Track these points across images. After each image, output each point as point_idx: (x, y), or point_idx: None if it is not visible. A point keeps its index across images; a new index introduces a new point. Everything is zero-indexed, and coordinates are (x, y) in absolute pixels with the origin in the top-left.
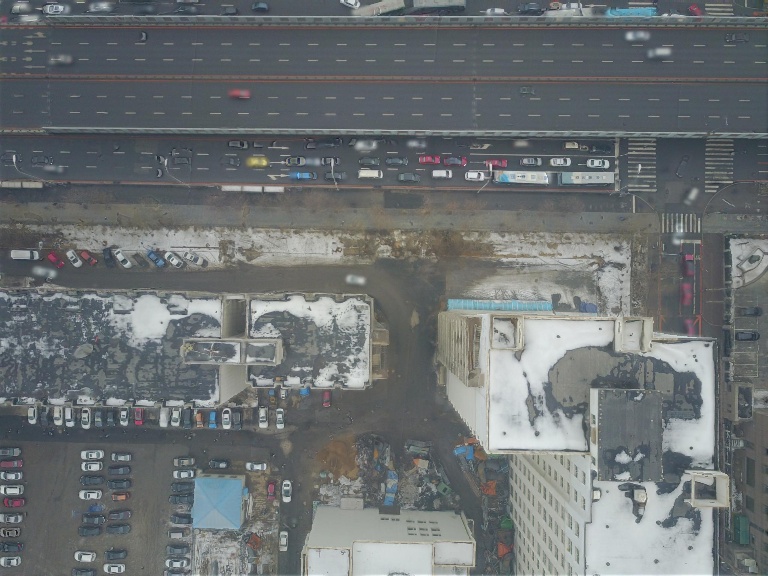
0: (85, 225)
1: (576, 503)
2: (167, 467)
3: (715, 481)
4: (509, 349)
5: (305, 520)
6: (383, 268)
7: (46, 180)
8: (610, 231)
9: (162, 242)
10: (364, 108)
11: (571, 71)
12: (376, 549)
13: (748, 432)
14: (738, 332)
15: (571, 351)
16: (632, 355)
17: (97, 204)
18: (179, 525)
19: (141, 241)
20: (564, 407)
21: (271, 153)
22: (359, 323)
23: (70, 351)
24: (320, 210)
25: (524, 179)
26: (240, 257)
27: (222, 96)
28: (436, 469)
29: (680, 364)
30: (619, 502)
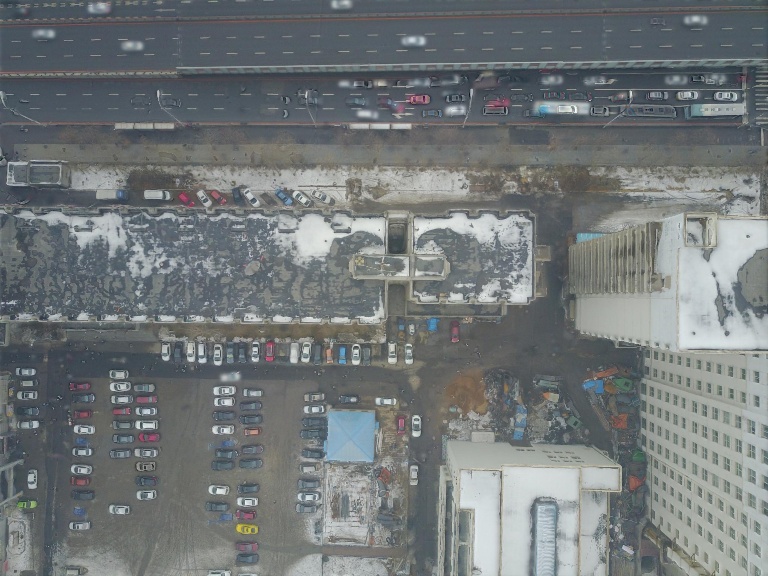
0: (214, 165)
1: (758, 408)
2: (297, 403)
3: None
4: (703, 247)
5: (435, 454)
6: (509, 204)
7: (179, 120)
8: (739, 164)
9: (289, 181)
10: (493, 43)
11: (703, 1)
12: (523, 473)
13: None
14: None
15: (760, 251)
16: None
17: (225, 145)
18: (310, 460)
19: (269, 181)
20: (754, 307)
21: (395, 92)
22: (521, 239)
23: (236, 270)
24: (445, 147)
25: (652, 112)
26: (367, 195)
27: (350, 34)
28: (565, 403)
29: None
30: None
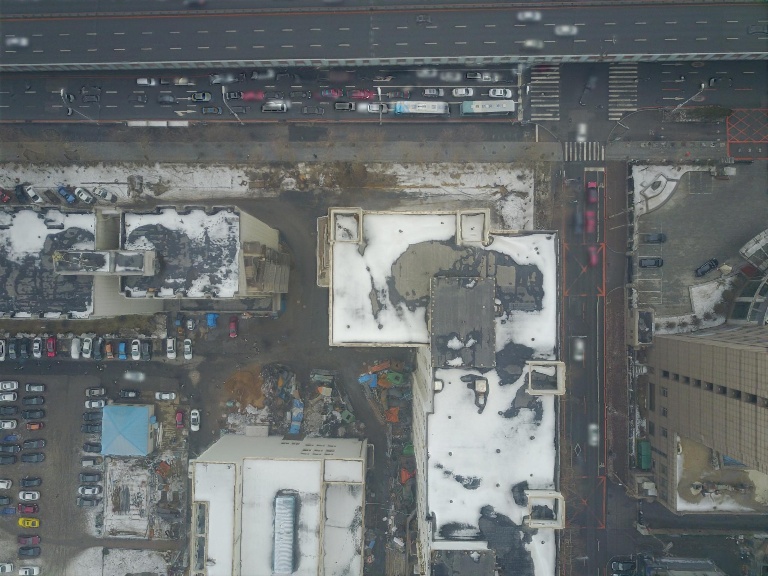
0: None
1: None
2: (80, 398)
3: (556, 371)
4: (347, 241)
5: None
6: (288, 200)
7: None
8: (512, 160)
9: (72, 178)
10: (263, 40)
11: None
12: (266, 466)
13: (650, 357)
14: (642, 259)
15: (413, 245)
16: (474, 249)
17: (10, 142)
18: (92, 454)
19: (52, 178)
20: (407, 300)
21: (178, 90)
22: (230, 235)
23: None
24: (225, 144)
25: (424, 109)
26: (148, 192)
27: (125, 32)
28: (341, 398)
29: (522, 257)
30: (461, 393)
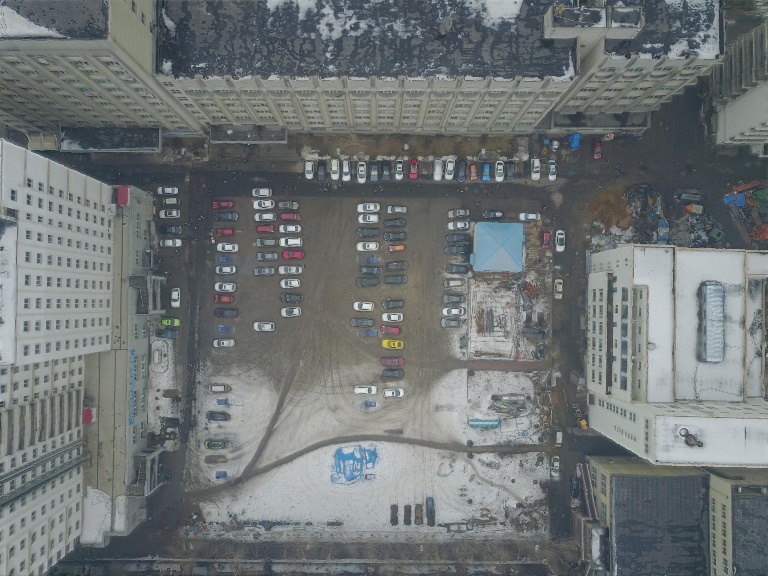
0: None
1: None
2: (441, 220)
3: None
4: None
5: (578, 269)
6: None
7: None
8: None
9: None
10: None
11: None
12: (689, 258)
13: None
14: None
15: None
16: None
17: None
18: (454, 276)
19: None
20: None
21: None
22: None
23: (426, 32)
24: None
25: None
26: None
27: None
28: (706, 217)
29: None
30: None
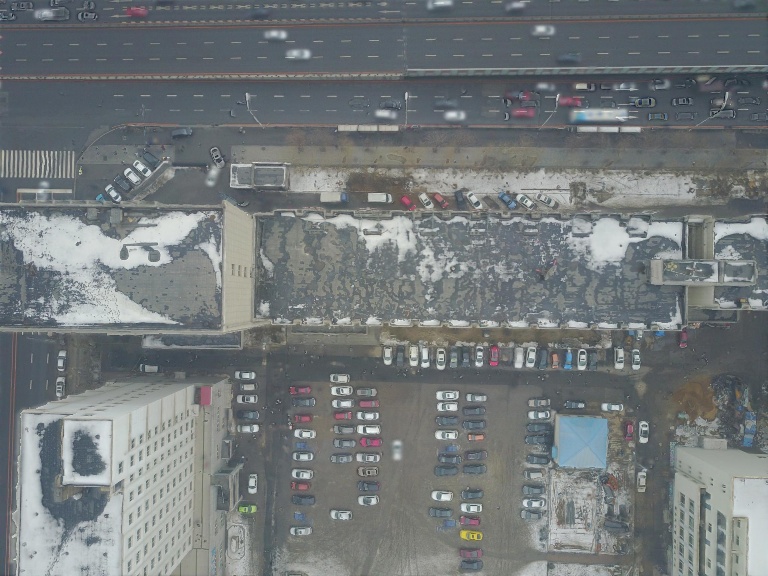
0: (436, 168)
1: None
2: (521, 408)
3: None
4: None
5: (662, 461)
6: (737, 208)
7: (406, 122)
8: None
9: (512, 184)
10: (728, 46)
11: None
12: None
13: None
14: None
15: None
16: None
17: (446, 148)
18: (534, 465)
19: (491, 184)
20: None
21: (618, 95)
22: None
23: (529, 274)
24: (671, 151)
25: None
26: (591, 199)
27: (581, 36)
28: None
29: None
30: None
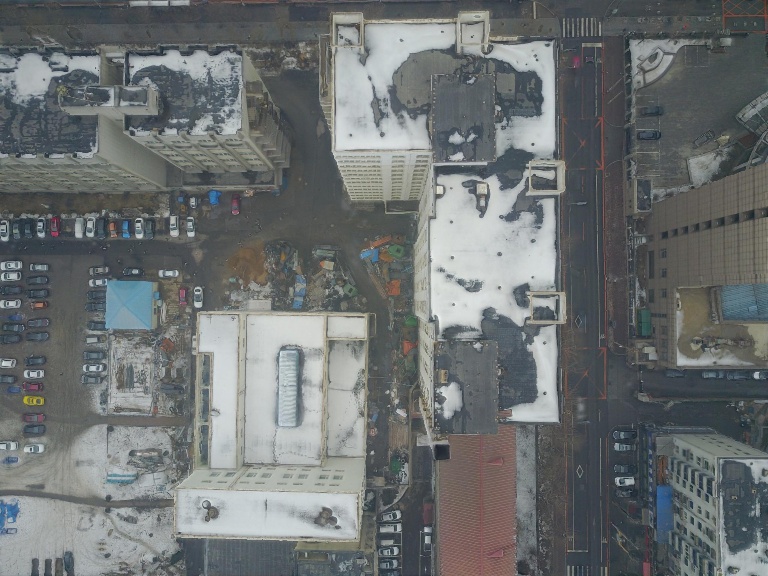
0: None
1: None
2: (83, 277)
3: (556, 175)
4: (349, 45)
5: None
6: (288, 79)
7: None
8: None
9: None
10: None
11: None
12: (269, 322)
13: (649, 226)
14: (639, 132)
15: (414, 54)
16: (474, 57)
17: (13, 26)
18: (96, 332)
19: None
20: (408, 109)
21: None
22: (233, 75)
23: None
24: (227, 25)
25: None
26: None
27: None
28: (343, 273)
29: (521, 64)
30: (463, 198)
